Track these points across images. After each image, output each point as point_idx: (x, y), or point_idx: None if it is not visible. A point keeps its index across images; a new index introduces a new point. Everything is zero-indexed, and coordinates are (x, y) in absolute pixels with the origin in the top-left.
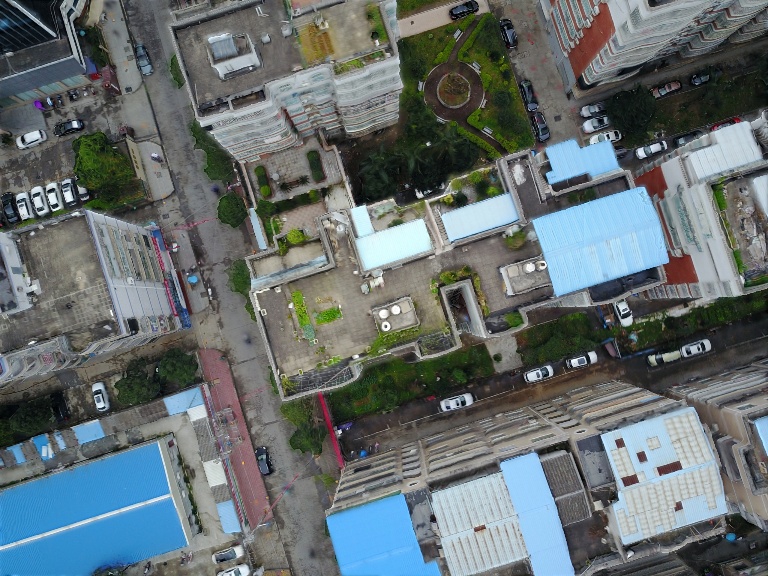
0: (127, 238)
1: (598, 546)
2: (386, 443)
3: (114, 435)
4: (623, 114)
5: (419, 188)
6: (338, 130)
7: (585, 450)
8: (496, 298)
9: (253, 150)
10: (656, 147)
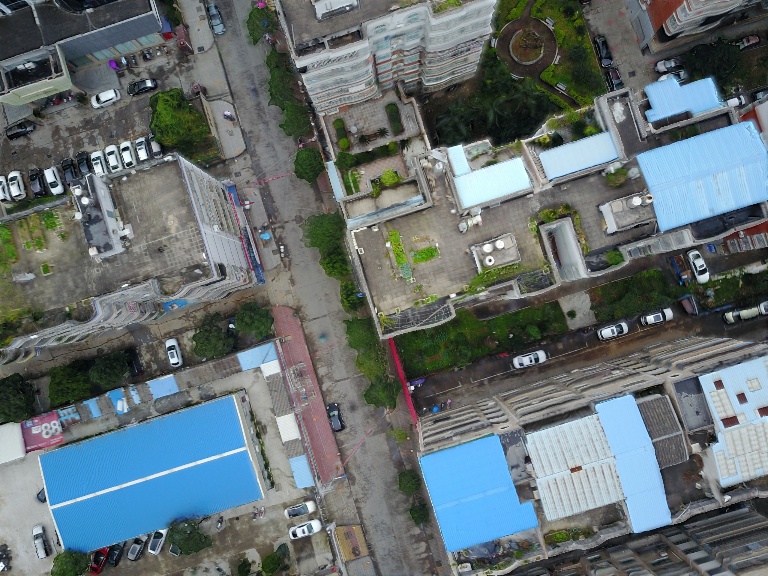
0: (210, 188)
1: (692, 491)
2: (458, 400)
3: (187, 391)
4: (703, 66)
5: (493, 144)
6: (415, 84)
7: (682, 392)
8: (595, 237)
9: (335, 100)
10: (733, 102)
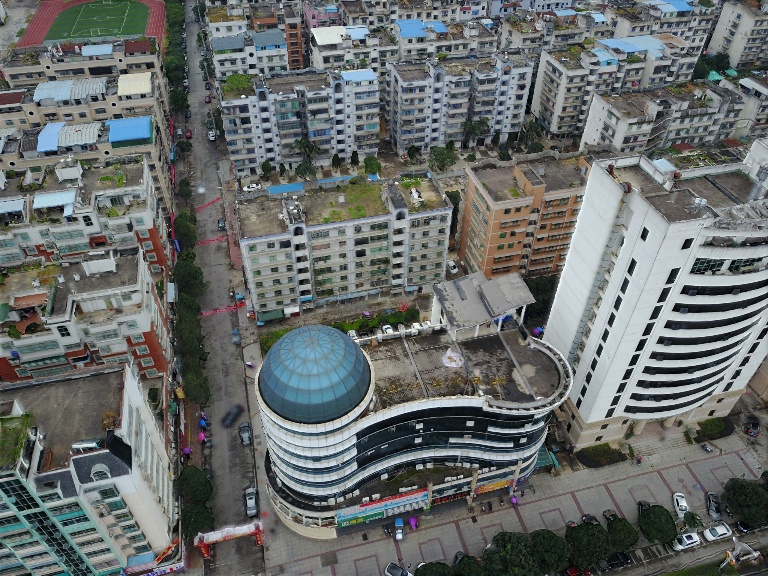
0: None
1: None
2: None
3: None
4: None
5: None
6: None
7: (13, 151)
8: None
9: None
10: None
